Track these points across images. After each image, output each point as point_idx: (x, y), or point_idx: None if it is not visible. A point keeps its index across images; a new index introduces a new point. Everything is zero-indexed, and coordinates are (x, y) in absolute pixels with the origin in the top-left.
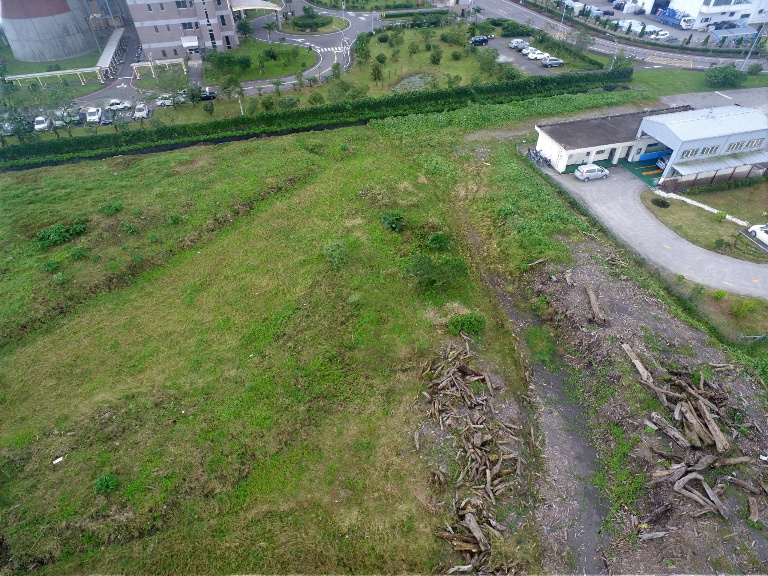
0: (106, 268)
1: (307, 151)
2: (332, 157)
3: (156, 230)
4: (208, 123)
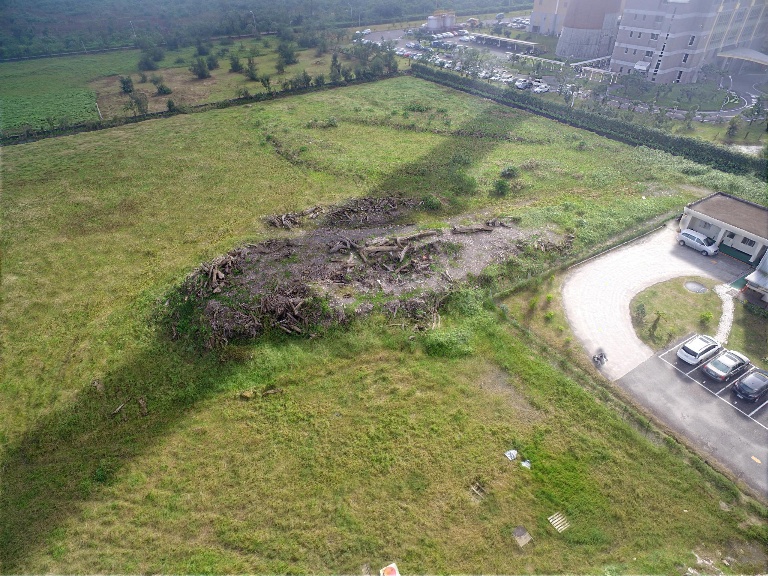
0: (402, 121)
1: (564, 137)
2: (567, 145)
3: (437, 122)
4: (546, 102)
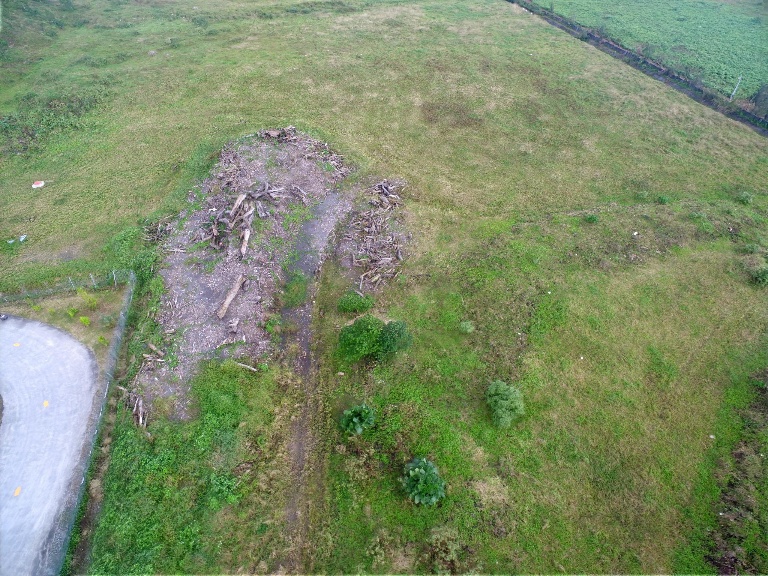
0: None
1: None
2: None
3: None
4: None
